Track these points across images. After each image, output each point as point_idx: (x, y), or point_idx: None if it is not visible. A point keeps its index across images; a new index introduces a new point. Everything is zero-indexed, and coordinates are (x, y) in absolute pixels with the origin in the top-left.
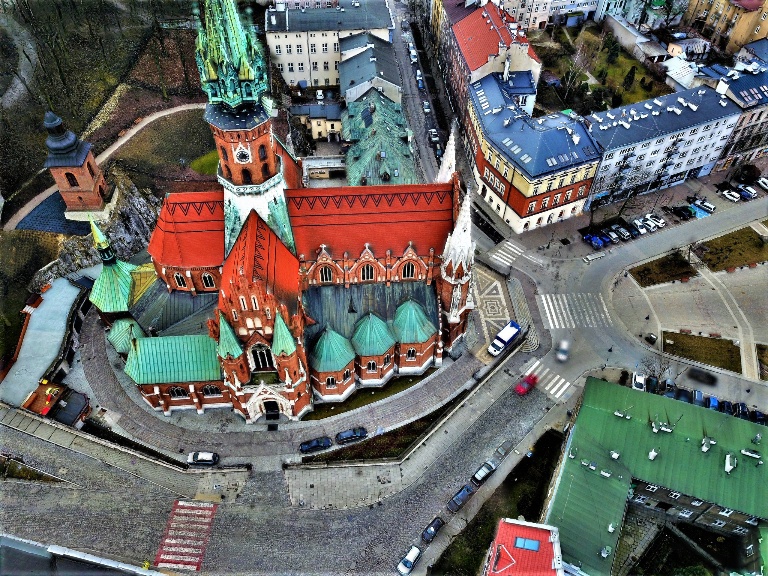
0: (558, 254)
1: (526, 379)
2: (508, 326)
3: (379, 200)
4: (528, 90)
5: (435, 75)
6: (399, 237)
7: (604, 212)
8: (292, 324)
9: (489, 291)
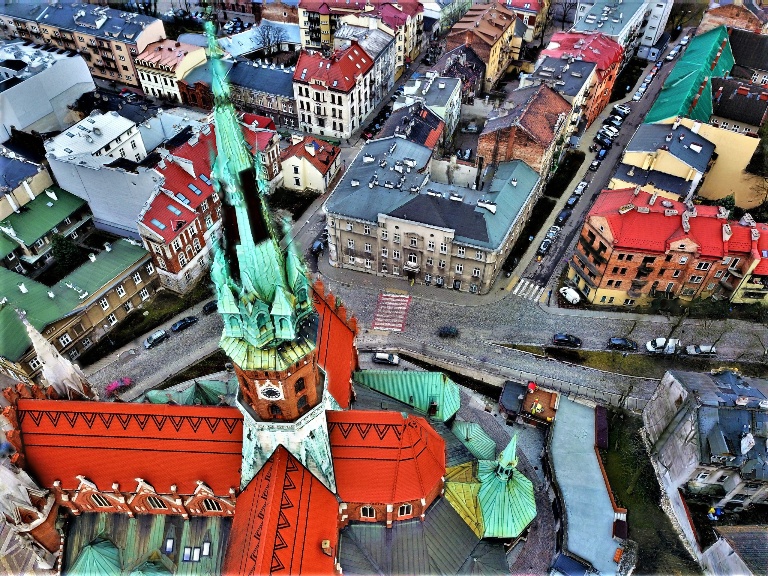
0: None
1: None
2: None
3: None
4: None
5: None
6: None
7: None
8: None
9: None
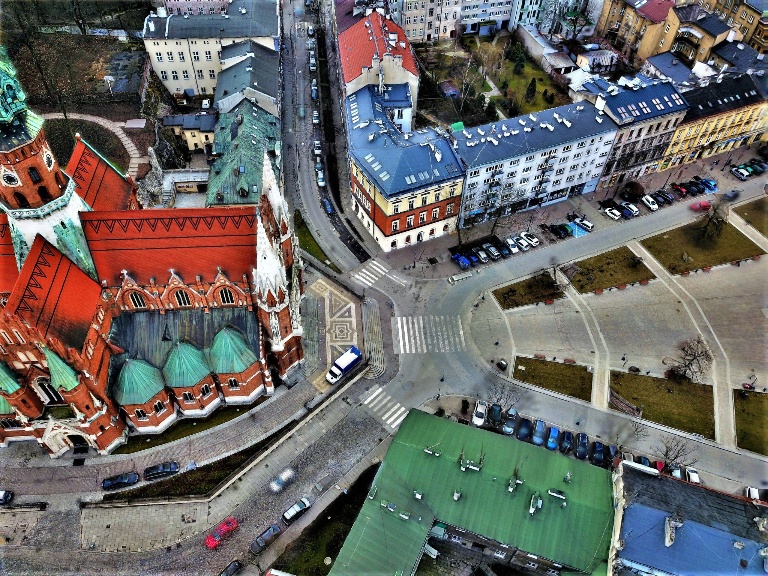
0: (422, 274)
1: (364, 408)
2: (348, 352)
3: (184, 224)
4: (403, 103)
5: (332, 84)
6: (209, 262)
7: (479, 230)
8: (71, 357)
9: (341, 313)
